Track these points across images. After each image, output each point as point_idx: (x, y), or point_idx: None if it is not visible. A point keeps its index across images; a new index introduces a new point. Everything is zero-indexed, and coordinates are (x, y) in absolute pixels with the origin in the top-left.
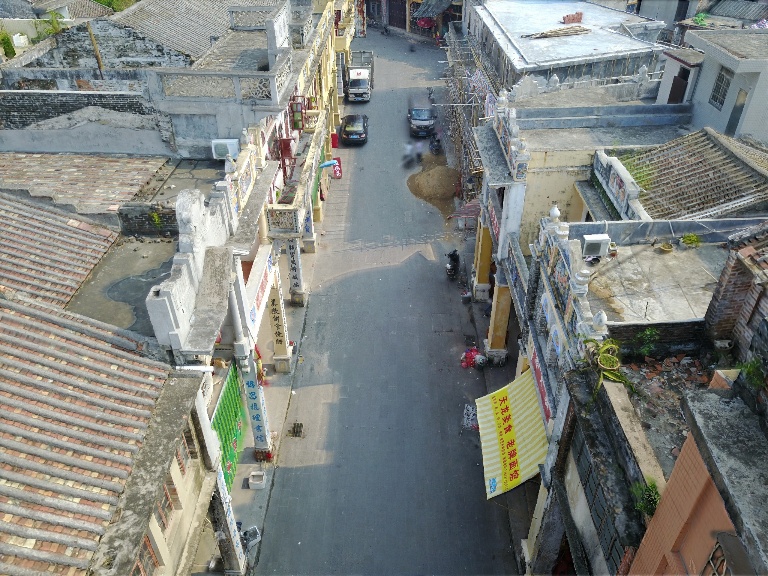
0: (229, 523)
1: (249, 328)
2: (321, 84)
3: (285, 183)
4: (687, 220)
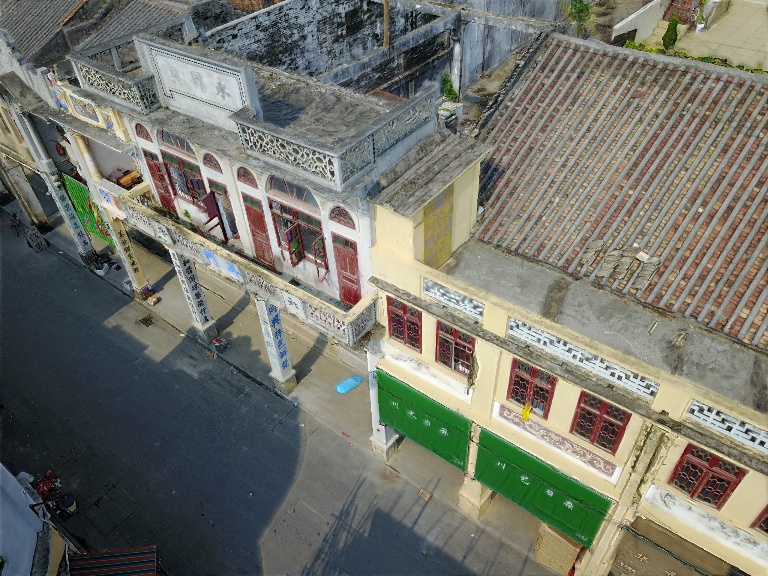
0: (62, 213)
1: (91, 188)
2: (639, 462)
3: (225, 241)
4: None
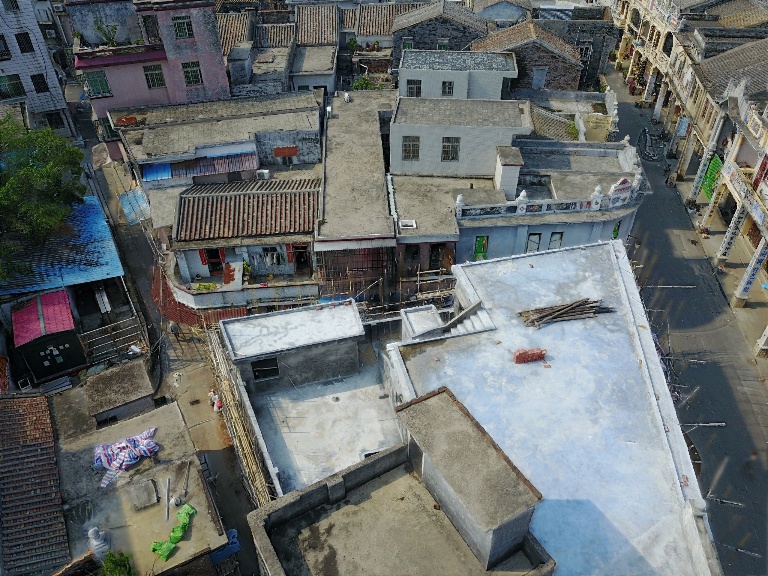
0: None
1: None
2: None
3: None
4: (563, 113)
